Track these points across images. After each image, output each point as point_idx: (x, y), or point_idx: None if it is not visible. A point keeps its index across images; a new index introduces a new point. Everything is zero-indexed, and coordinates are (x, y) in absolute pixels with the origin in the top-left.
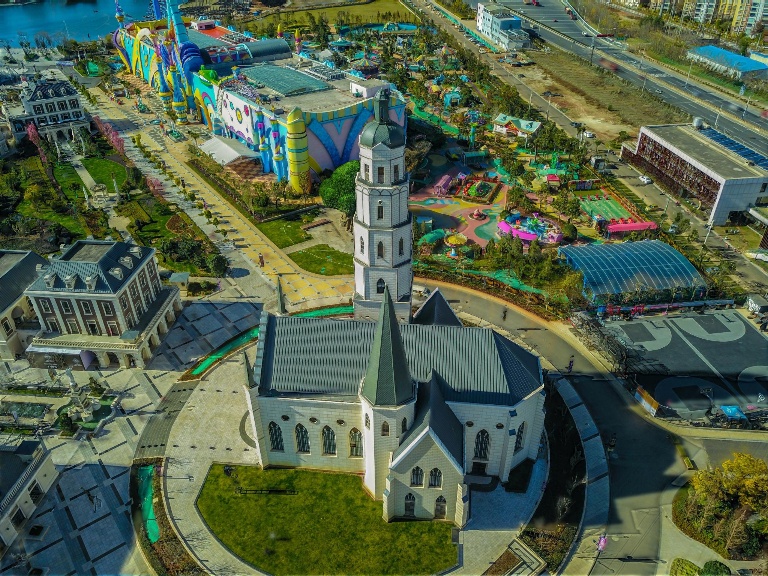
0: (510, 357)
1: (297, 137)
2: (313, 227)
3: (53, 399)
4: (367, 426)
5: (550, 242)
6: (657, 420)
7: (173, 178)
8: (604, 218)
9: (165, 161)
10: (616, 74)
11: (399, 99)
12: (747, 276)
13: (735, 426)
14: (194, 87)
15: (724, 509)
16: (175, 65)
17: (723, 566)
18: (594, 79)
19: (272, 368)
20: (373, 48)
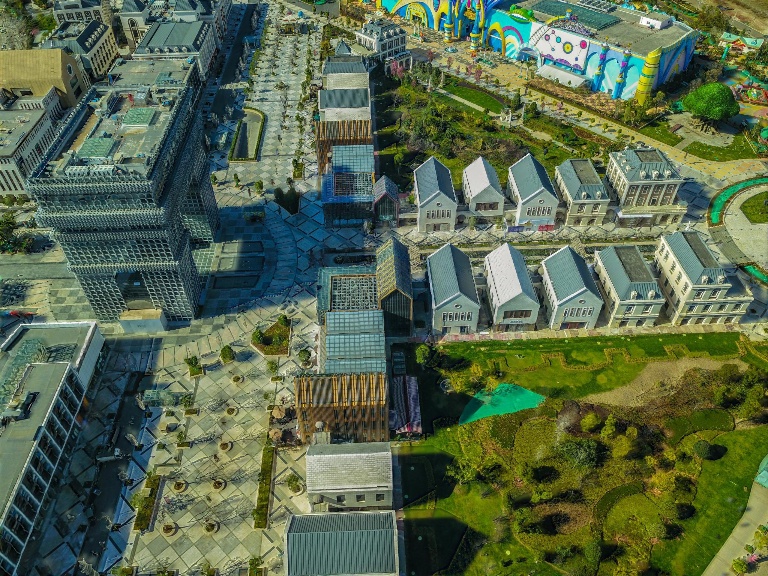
0: None
1: (656, 67)
2: (676, 130)
3: (652, 242)
4: None
5: None
6: None
7: None
8: None
9: None
10: None
11: None
12: None
13: None
14: (491, 21)
15: None
16: (471, 2)
17: None
18: None
19: None
20: None
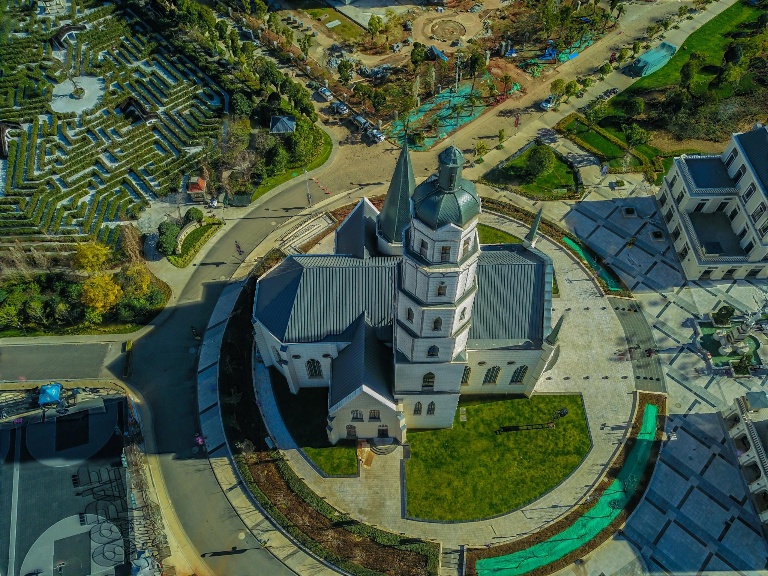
0: None
1: None
2: None
3: None
4: None
5: None
6: (131, 394)
7: None
8: None
9: None
10: None
11: None
12: None
13: None
14: None
15: None
16: None
17: (161, 240)
18: None
19: None
20: None
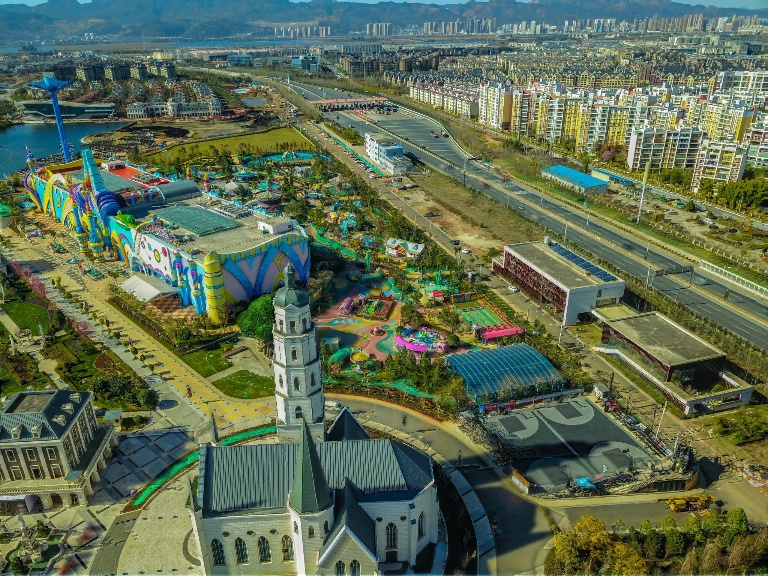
0: (406, 460)
1: (214, 276)
2: (233, 355)
3: None
4: (296, 532)
5: (439, 351)
6: (530, 497)
7: (96, 318)
8: (481, 327)
9: (86, 300)
10: (486, 193)
11: (302, 235)
12: (594, 367)
13: (588, 494)
14: (111, 229)
15: (581, 563)
16: None
17: None
18: (468, 199)
19: (212, 492)
20: (274, 178)
